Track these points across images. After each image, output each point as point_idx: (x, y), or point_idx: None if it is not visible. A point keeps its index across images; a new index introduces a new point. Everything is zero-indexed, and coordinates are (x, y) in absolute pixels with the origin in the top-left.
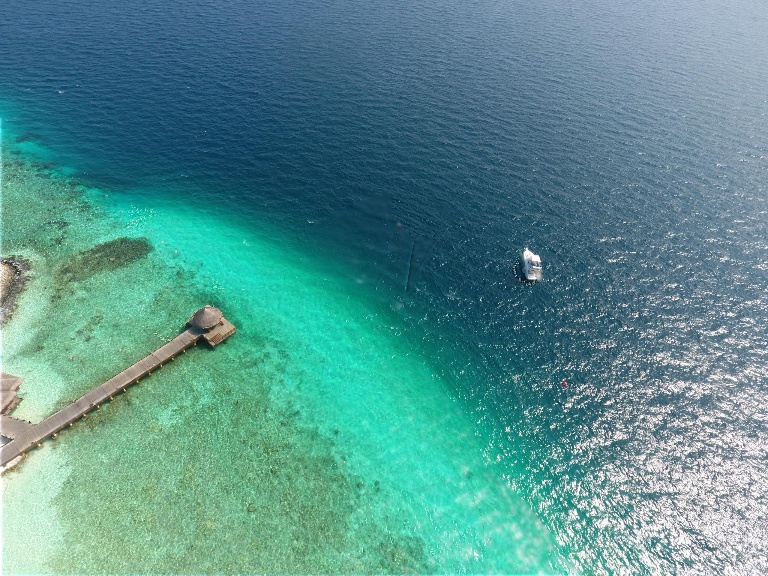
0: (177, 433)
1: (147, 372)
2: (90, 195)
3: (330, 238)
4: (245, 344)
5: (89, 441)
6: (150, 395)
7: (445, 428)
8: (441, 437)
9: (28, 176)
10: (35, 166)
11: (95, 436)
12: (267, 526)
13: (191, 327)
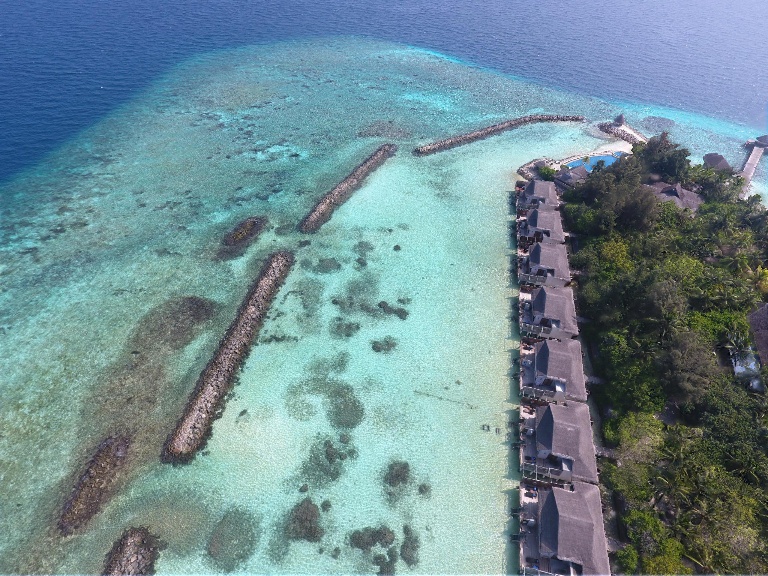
0: None
1: (759, 159)
2: (597, 99)
3: (767, 116)
4: None
5: (765, 180)
6: (767, 168)
7: None
8: None
9: (548, 90)
10: None
11: (765, 179)
12: None
13: (755, 145)
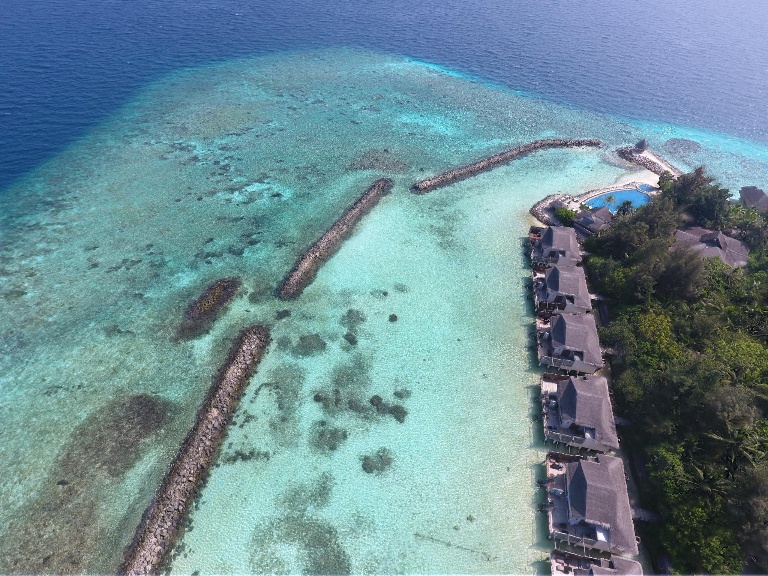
0: None
1: None
2: (612, 118)
3: None
4: None
5: None
6: None
7: None
8: None
9: (559, 108)
10: (551, 103)
11: None
12: None
13: None
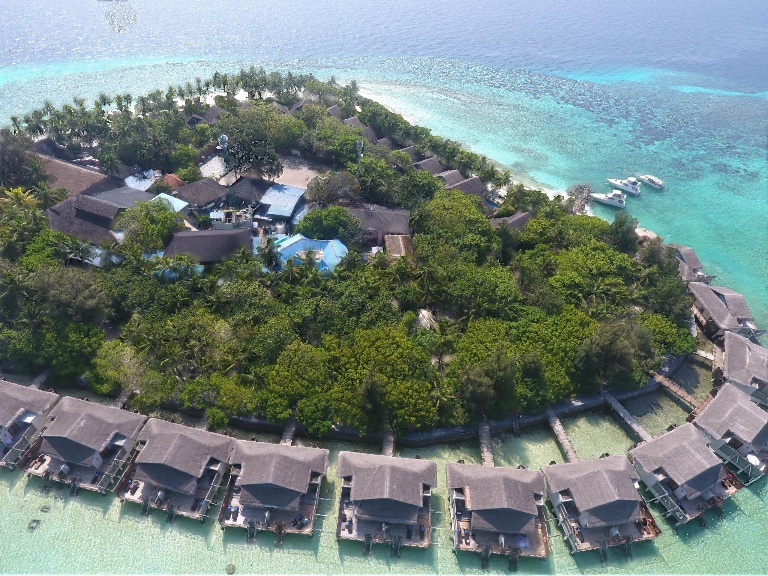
0: None
1: None
2: None
3: None
4: None
5: None
6: None
7: (2, 72)
8: None
9: None
10: None
11: None
12: (6, 97)
13: None
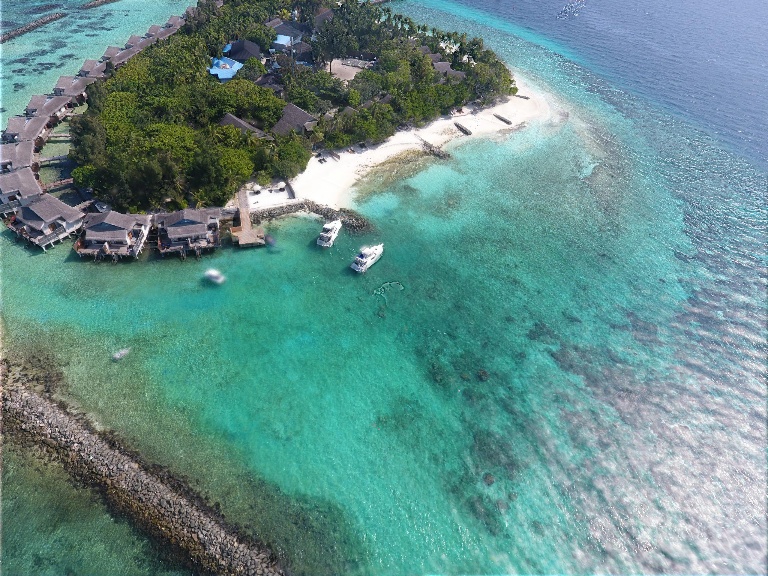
0: (403, 8)
1: None
2: None
3: None
4: (411, 1)
5: None
6: (391, 4)
7: None
8: (476, 14)
9: None
10: None
11: None
12: None
13: None
